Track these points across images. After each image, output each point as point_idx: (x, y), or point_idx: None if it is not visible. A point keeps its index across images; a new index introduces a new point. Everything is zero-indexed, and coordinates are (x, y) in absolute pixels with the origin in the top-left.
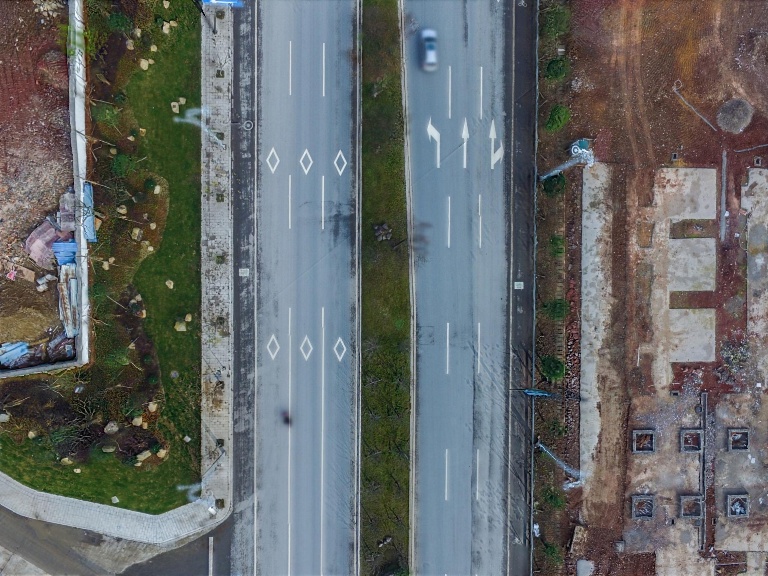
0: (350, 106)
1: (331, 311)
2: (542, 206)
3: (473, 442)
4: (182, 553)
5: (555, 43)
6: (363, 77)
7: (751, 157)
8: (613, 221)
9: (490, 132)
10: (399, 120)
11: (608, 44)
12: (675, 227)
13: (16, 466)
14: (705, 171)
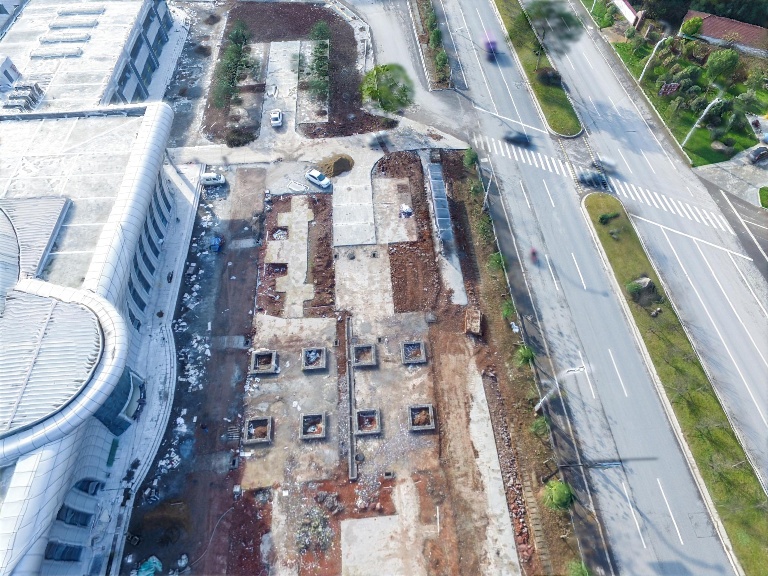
0: None
1: None
2: None
3: (602, 405)
4: None
5: None
6: None
7: None
8: None
9: None
10: None
11: None
12: None
13: None
14: None
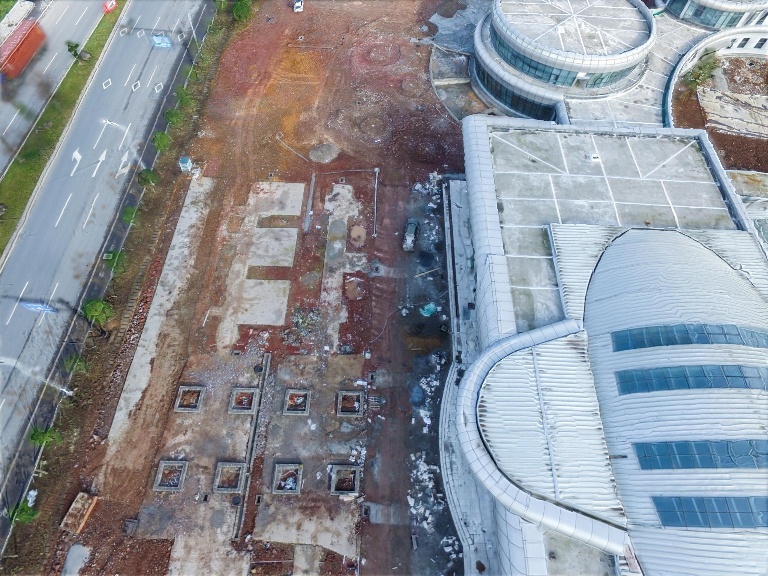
0: (20, 140)
1: None
2: (149, 202)
3: (3, 391)
4: None
5: (192, 113)
6: (36, 125)
7: (336, 178)
8: (208, 214)
9: (123, 157)
10: (51, 147)
11: (232, 114)
12: (263, 220)
13: None
14: (295, 184)
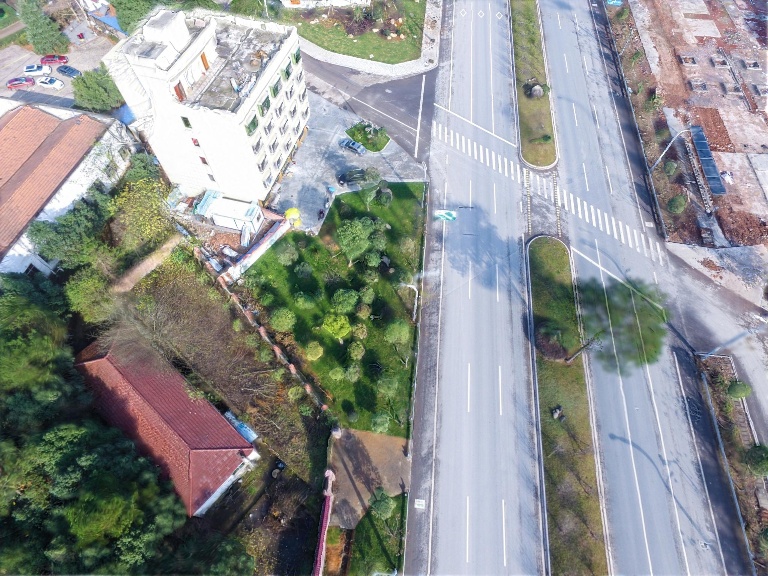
0: None
1: (494, 4)
2: None
3: (580, 53)
4: (406, 80)
5: None
6: None
7: None
8: None
9: None
10: None
11: None
12: None
13: (322, 38)
14: None
